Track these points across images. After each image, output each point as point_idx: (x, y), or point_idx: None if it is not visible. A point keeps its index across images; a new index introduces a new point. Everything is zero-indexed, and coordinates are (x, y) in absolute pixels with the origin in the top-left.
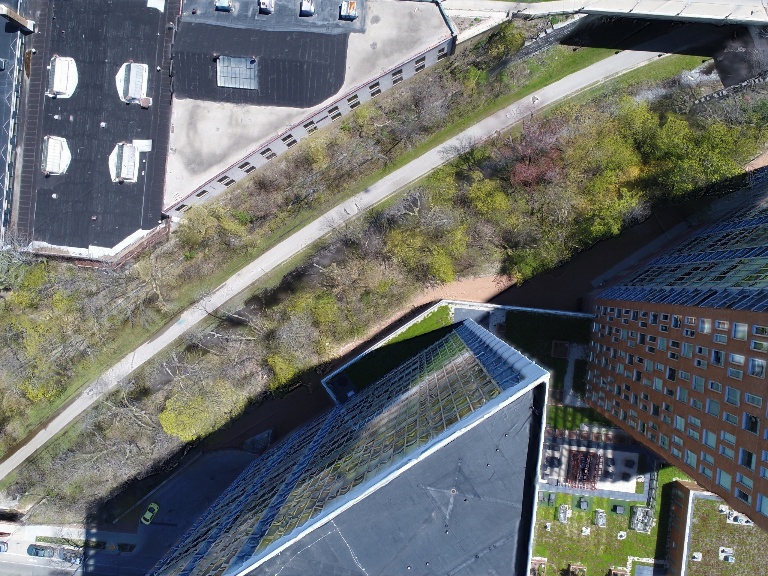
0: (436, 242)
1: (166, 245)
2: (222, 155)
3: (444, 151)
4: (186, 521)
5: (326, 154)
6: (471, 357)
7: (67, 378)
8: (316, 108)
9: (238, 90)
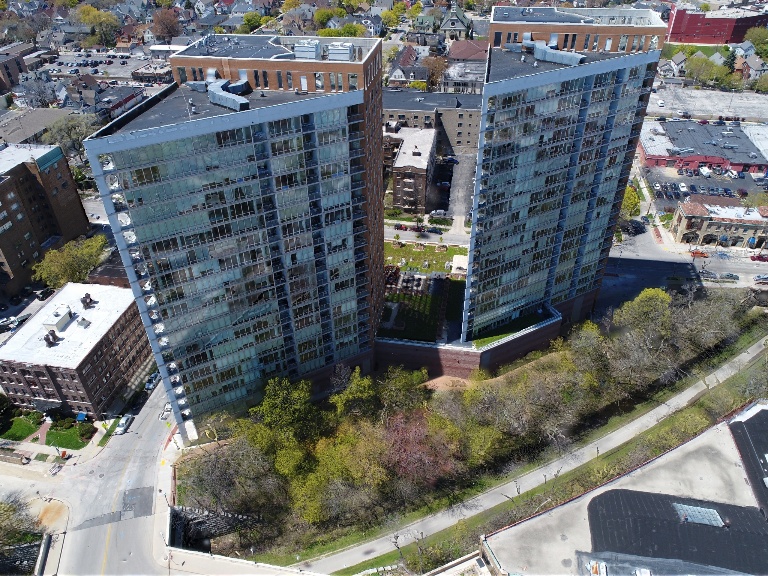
0: (481, 431)
1: None
2: (689, 458)
3: (477, 507)
4: (636, 288)
5: None
6: (488, 201)
7: (766, 371)
8: (610, 488)
9: None
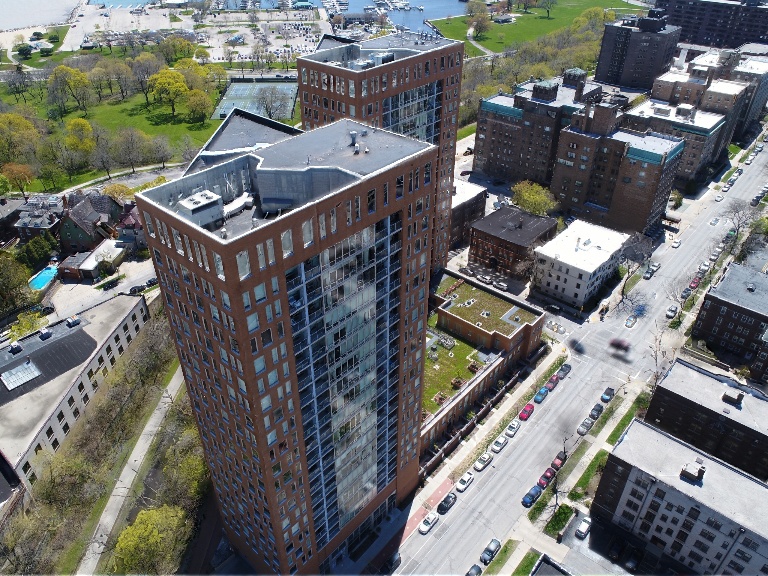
0: None
1: (25, 533)
2: (40, 415)
3: None
4: None
5: (114, 403)
6: None
7: None
8: (89, 359)
9: (27, 384)
